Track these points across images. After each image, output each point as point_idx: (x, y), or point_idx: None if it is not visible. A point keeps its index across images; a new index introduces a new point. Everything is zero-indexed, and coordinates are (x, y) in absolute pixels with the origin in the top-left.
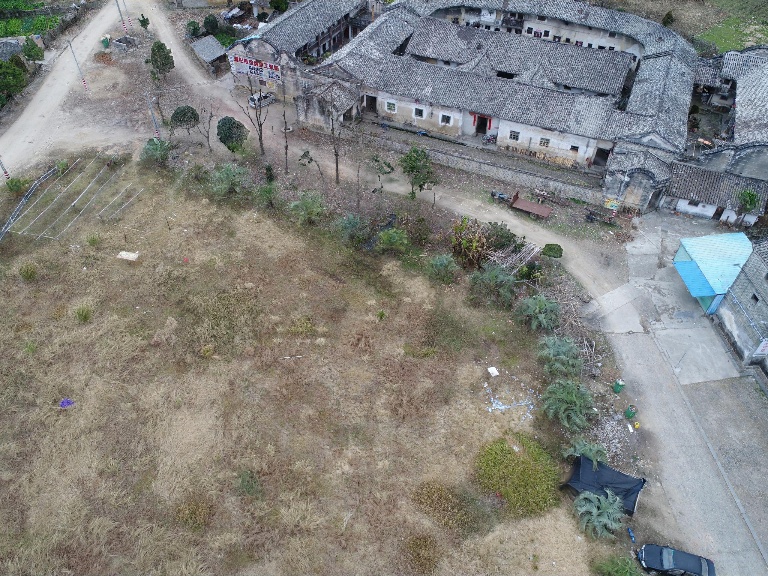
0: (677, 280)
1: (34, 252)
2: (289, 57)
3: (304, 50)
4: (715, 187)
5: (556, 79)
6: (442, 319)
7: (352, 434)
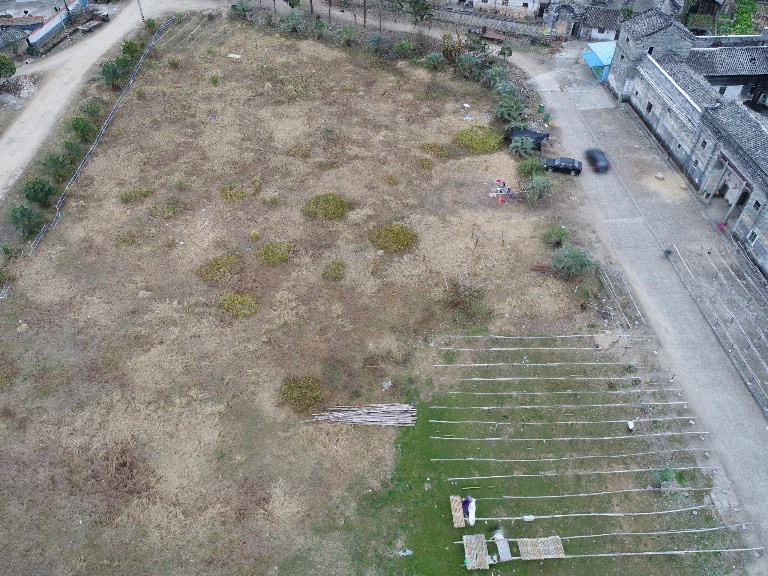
0: (585, 69)
1: None
2: None
3: None
4: (615, 19)
5: None
6: (436, 85)
7: (384, 127)
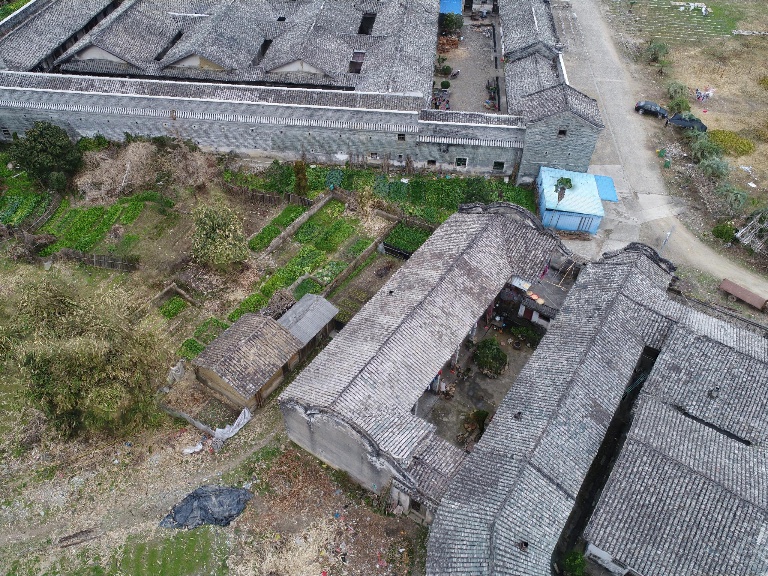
0: None
1: None
2: None
3: None
4: None
5: (763, 456)
6: None
7: None
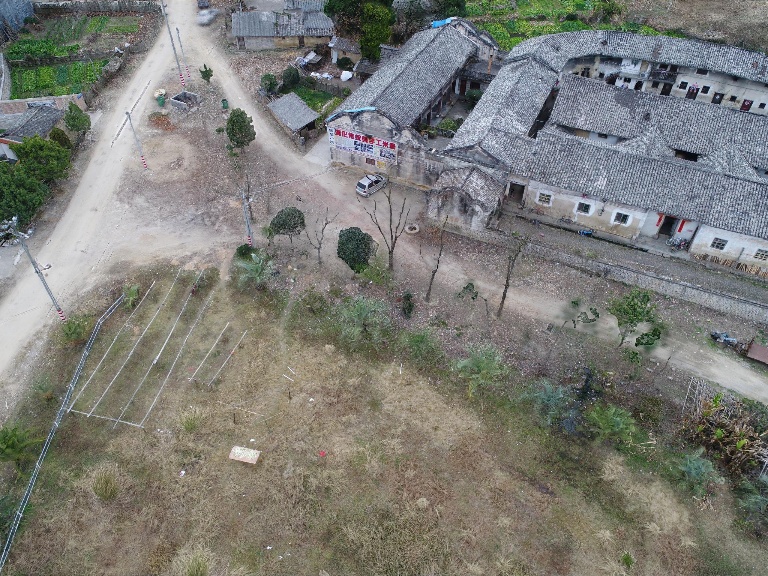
0: None
1: (109, 444)
2: (413, 134)
3: (417, 117)
4: None
5: (758, 163)
6: (715, 566)
7: None
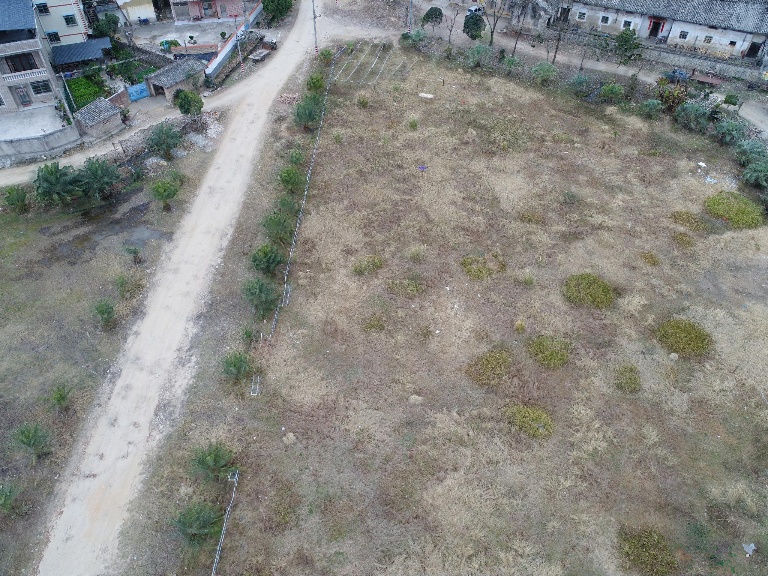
0: None
1: None
2: None
3: None
4: None
5: None
6: (658, 138)
7: (617, 189)
